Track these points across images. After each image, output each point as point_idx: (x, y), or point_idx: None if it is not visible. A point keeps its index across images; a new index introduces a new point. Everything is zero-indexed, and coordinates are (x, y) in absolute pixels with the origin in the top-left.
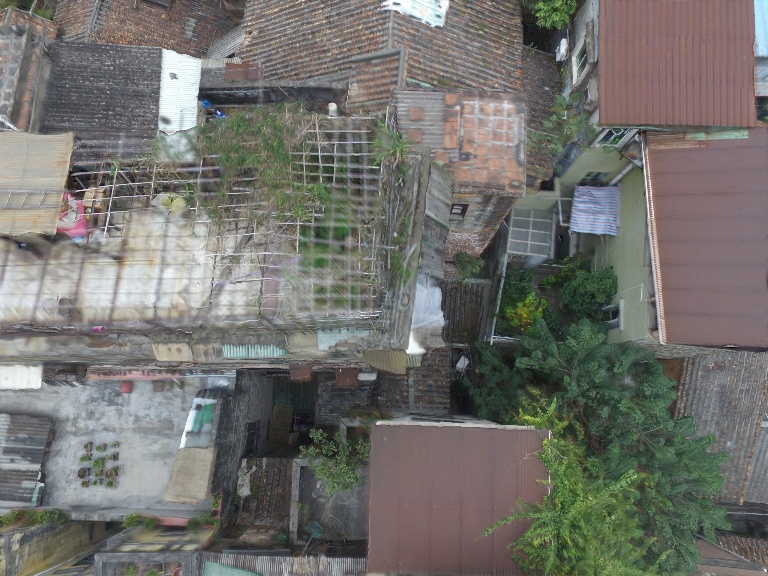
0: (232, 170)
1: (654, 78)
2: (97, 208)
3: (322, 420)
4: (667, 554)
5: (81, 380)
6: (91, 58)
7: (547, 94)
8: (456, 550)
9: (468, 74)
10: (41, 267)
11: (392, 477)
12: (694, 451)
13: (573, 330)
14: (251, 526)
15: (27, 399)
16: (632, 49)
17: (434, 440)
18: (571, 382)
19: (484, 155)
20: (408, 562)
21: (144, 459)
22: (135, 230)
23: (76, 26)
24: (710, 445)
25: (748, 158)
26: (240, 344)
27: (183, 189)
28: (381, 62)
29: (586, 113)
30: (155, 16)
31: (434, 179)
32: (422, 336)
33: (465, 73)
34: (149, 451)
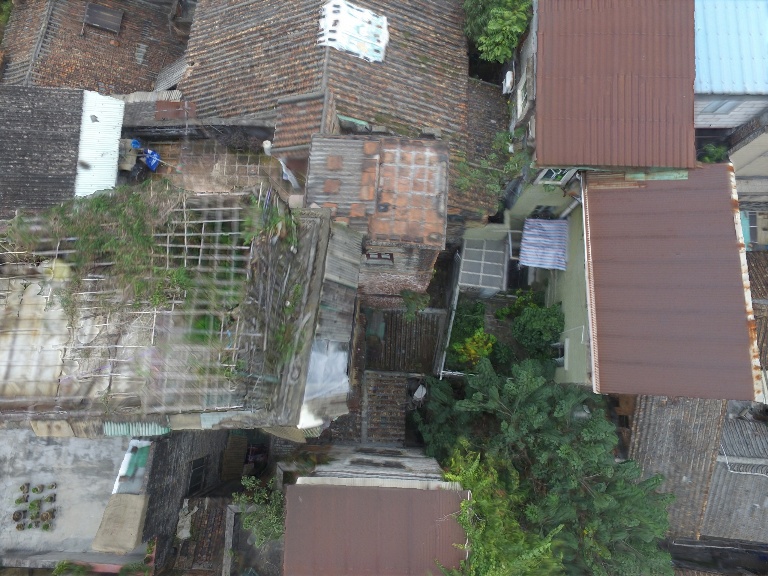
0: (89, 254)
1: (592, 117)
2: None
3: (277, 451)
4: None
5: None
6: (8, 101)
7: (493, 127)
8: None
9: (408, 110)
10: None
11: (307, 539)
12: (637, 496)
13: (515, 371)
14: (188, 571)
15: None
16: (570, 87)
17: (351, 500)
18: (508, 428)
19: (403, 206)
20: None
21: (82, 500)
22: None
23: (21, 54)
24: (665, 480)
25: (687, 200)
26: (120, 422)
27: None
28: (306, 105)
29: (529, 149)
30: (104, 42)
31: (338, 240)
32: (319, 407)
33: (405, 109)
34: (87, 492)
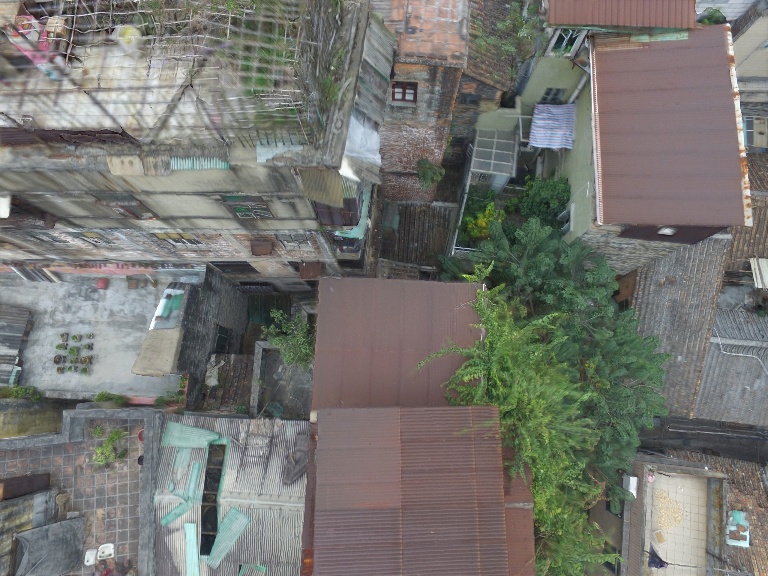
0: None
1: None
2: (59, 33)
3: None
4: (588, 395)
5: (59, 275)
6: None
7: (508, 11)
8: (394, 391)
9: None
10: (8, 92)
11: (337, 324)
12: (635, 341)
13: (524, 228)
14: None
15: (7, 293)
16: None
17: (377, 292)
18: (518, 269)
19: (429, 29)
20: (350, 401)
21: (117, 350)
22: (95, 62)
23: None
24: None
25: (687, 57)
26: (186, 156)
27: (139, 24)
28: None
29: (541, 23)
30: None
31: (374, 31)
32: (357, 166)
33: None
34: (122, 343)
